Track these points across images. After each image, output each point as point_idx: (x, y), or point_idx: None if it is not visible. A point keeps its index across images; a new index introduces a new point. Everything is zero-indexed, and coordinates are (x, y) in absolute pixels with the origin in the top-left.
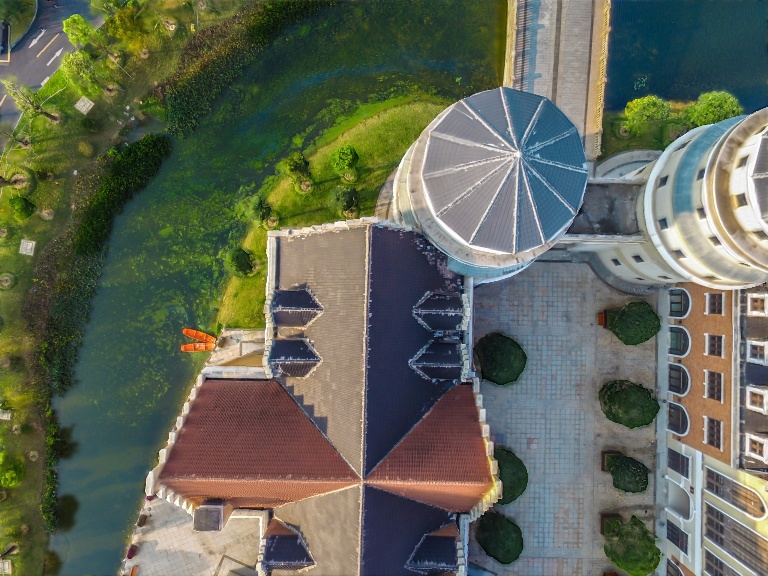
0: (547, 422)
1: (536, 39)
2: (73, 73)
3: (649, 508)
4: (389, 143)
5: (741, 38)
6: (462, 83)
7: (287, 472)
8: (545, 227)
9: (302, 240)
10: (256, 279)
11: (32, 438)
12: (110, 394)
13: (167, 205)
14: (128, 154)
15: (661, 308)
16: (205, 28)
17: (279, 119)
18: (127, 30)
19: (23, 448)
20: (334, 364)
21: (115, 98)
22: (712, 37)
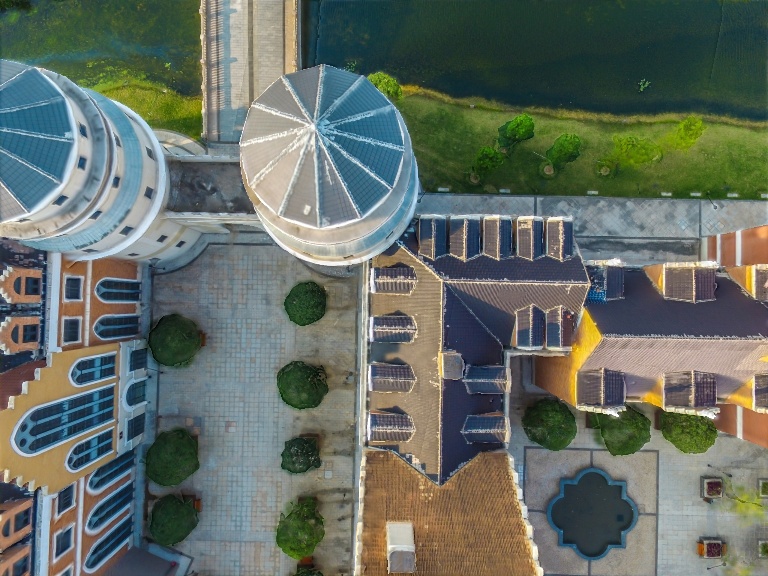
0: (245, 405)
1: (229, 23)
2: None
3: (348, 491)
4: None
5: (452, 23)
6: (171, 68)
7: None
8: (21, 195)
9: None
10: None
11: None
12: None
13: None
14: None
15: (361, 291)
16: None
17: None
18: None
19: None
20: None
21: None
22: (423, 22)
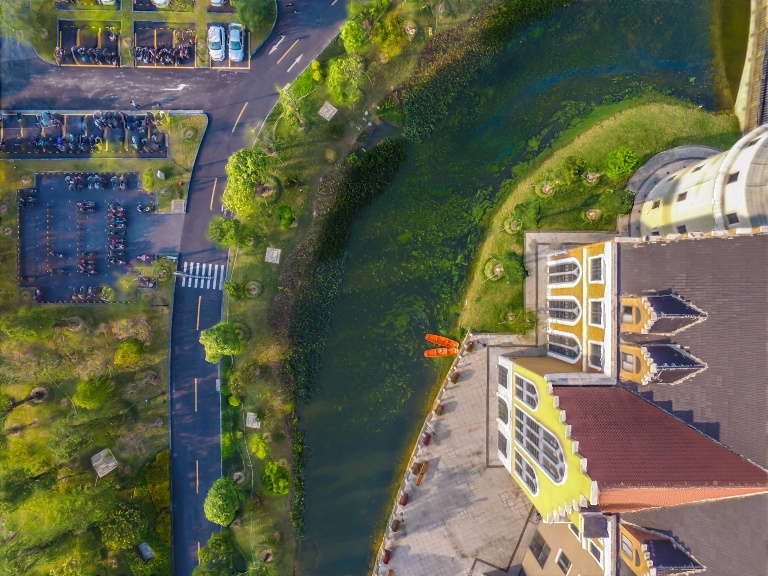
0: None
1: None
2: (343, 80)
3: None
4: (629, 145)
5: None
6: (696, 83)
7: (710, 479)
8: None
9: (662, 246)
10: (501, 283)
11: (281, 446)
12: (354, 400)
13: (405, 210)
14: (368, 160)
15: None
16: (442, 32)
17: (514, 122)
18: (397, 36)
19: (273, 456)
20: (731, 370)
21: (356, 104)
22: None
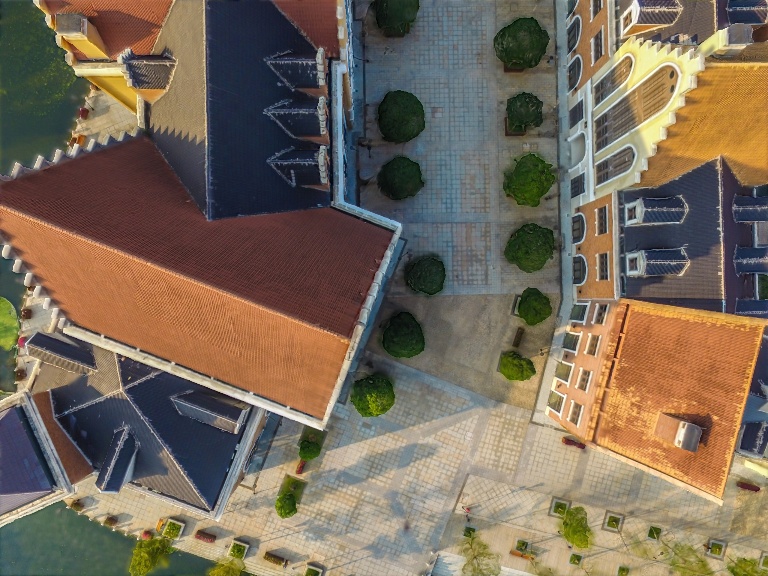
0: (450, 91)
1: None
2: None
3: (553, 171)
4: None
5: None
6: None
7: None
8: None
9: None
10: None
11: None
12: (19, 85)
13: None
14: None
15: None
16: None
17: None
18: None
19: None
20: None
21: None
22: None
